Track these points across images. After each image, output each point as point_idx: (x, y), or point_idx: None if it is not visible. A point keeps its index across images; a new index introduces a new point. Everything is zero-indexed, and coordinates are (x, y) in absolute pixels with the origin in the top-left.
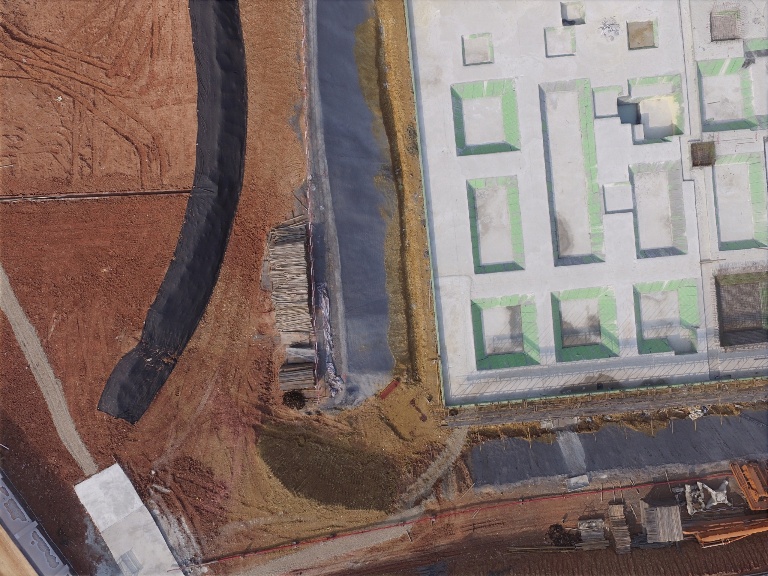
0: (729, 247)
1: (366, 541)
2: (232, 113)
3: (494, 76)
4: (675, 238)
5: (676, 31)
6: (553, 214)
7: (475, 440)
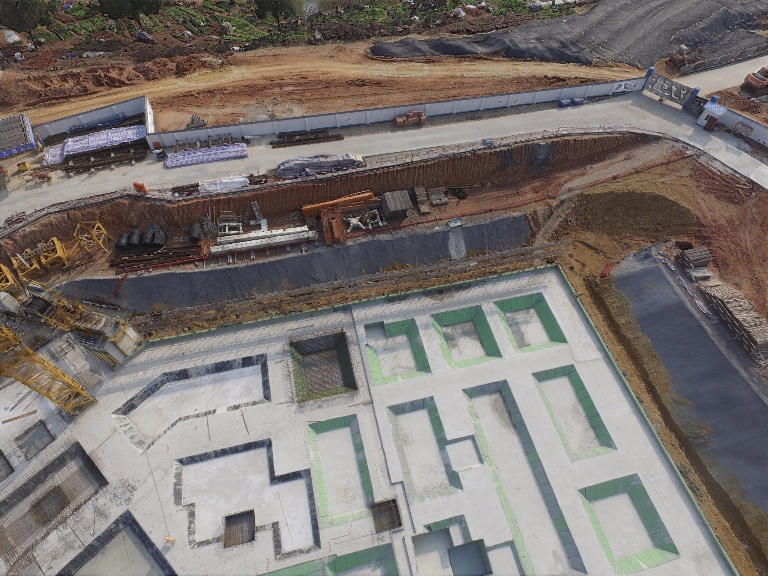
0: (345, 421)
1: (590, 178)
2: None
3: None
4: (397, 424)
5: None
6: (519, 431)
7: None
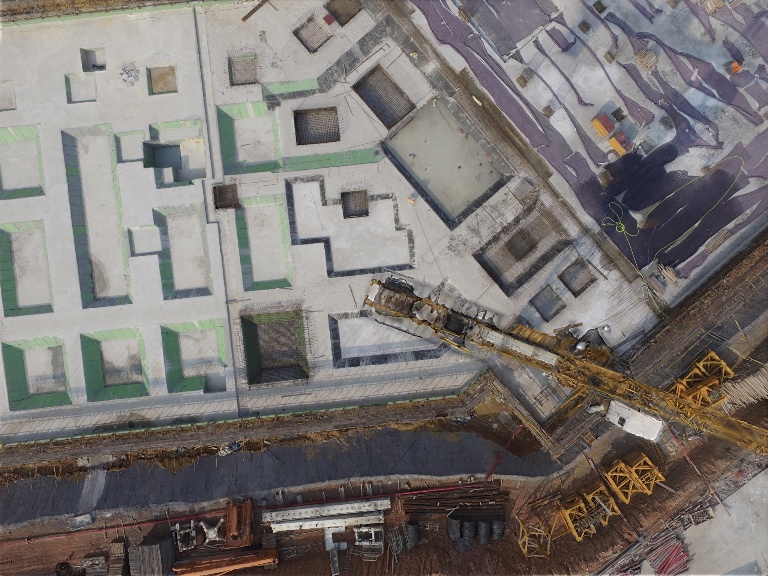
0: (257, 287)
1: None
2: None
3: (17, 122)
4: (207, 279)
5: (195, 76)
6: (87, 257)
7: (8, 479)
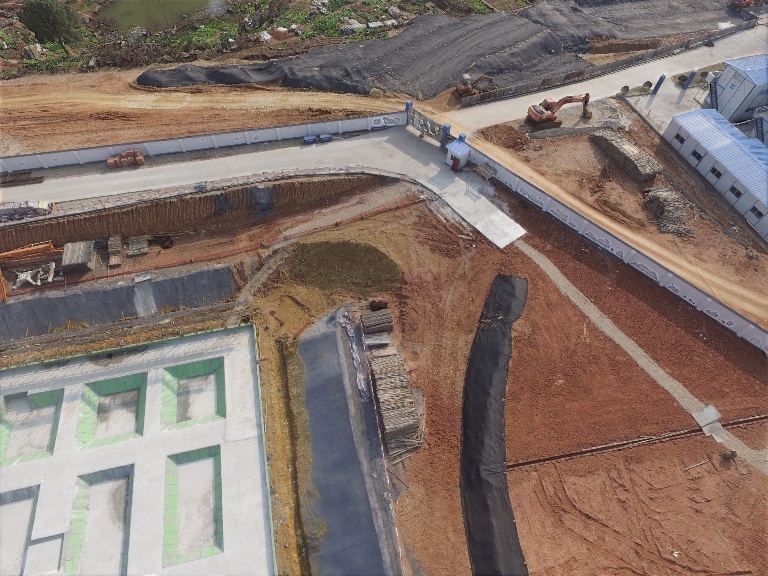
0: None
1: (313, 225)
2: (488, 569)
3: None
4: None
5: None
6: (126, 527)
7: None
